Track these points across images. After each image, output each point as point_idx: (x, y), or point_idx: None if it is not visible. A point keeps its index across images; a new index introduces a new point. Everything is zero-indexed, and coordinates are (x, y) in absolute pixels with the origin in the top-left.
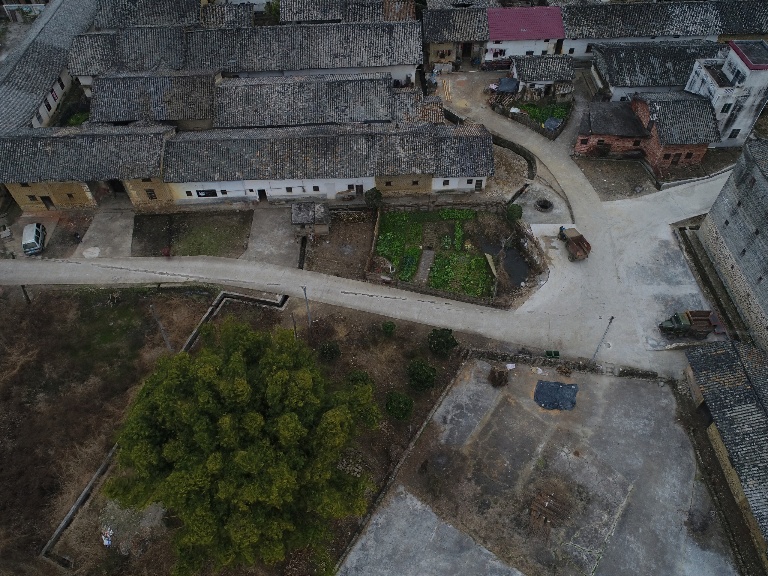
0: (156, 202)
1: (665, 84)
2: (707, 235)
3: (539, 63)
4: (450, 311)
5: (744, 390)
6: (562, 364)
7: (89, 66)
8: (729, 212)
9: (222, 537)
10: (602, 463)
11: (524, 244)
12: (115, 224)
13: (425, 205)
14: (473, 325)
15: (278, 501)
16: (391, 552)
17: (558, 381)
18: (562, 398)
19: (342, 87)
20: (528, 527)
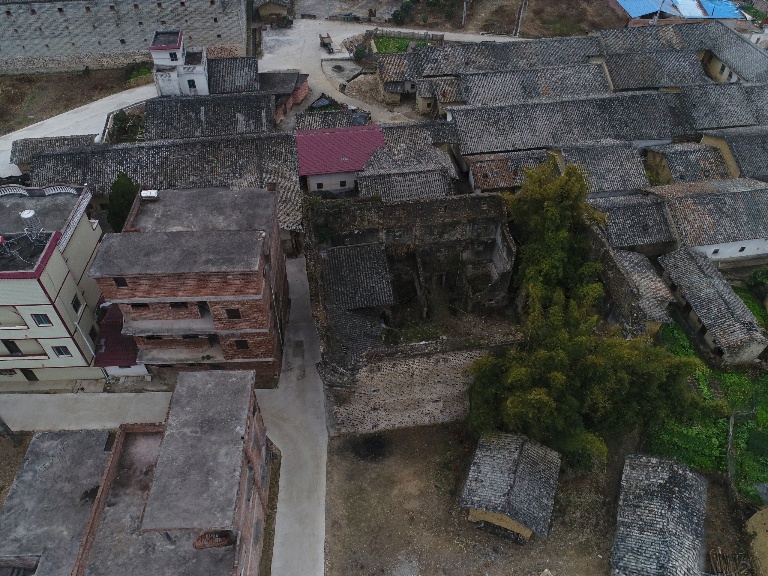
0: None
1: None
2: None
3: None
4: None
5: None
6: None
7: None
8: None
9: None
10: None
11: None
12: None
13: None
14: (384, 29)
15: None
16: None
17: None
18: None
19: None
20: None
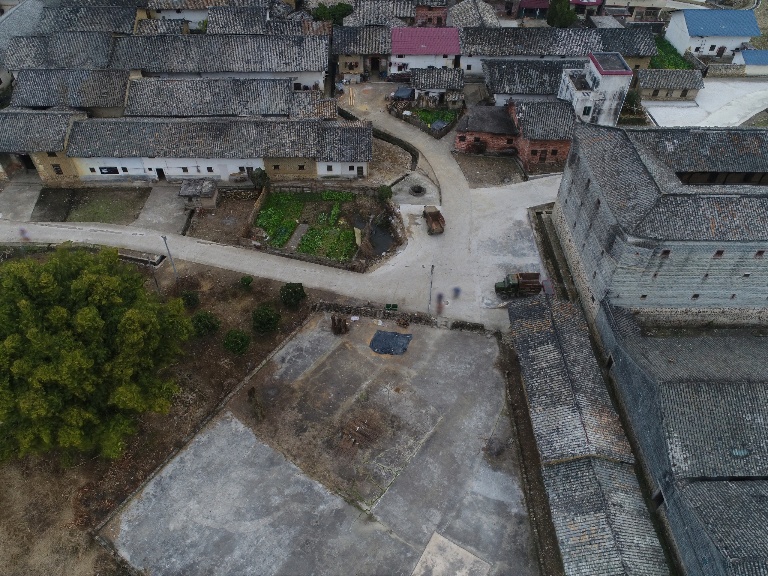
0: (63, 177)
1: (541, 92)
2: (556, 216)
3: (432, 73)
4: (310, 272)
5: (548, 333)
6: (400, 316)
7: (22, 63)
8: (567, 191)
9: (21, 417)
10: (419, 398)
11: (391, 221)
12: (22, 195)
13: (308, 187)
14: (328, 284)
15: (72, 384)
16: (206, 465)
17: (395, 331)
18: (395, 345)
19: (246, 85)
20: (337, 447)
